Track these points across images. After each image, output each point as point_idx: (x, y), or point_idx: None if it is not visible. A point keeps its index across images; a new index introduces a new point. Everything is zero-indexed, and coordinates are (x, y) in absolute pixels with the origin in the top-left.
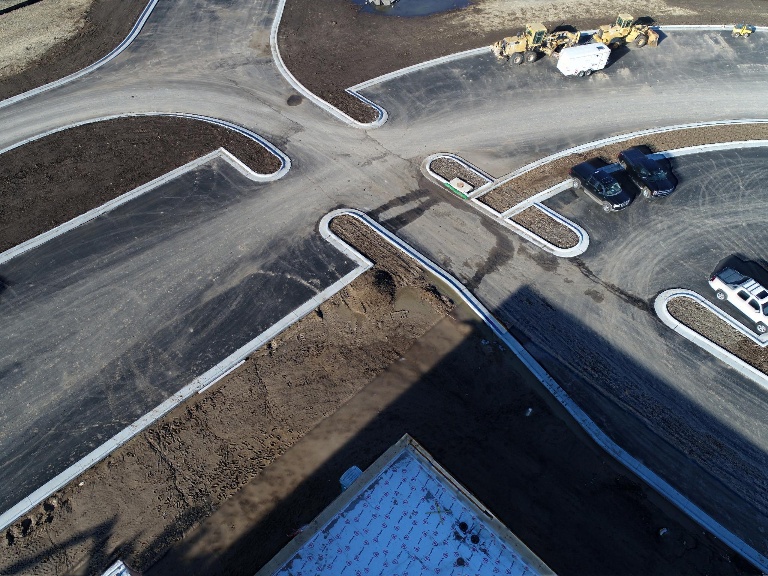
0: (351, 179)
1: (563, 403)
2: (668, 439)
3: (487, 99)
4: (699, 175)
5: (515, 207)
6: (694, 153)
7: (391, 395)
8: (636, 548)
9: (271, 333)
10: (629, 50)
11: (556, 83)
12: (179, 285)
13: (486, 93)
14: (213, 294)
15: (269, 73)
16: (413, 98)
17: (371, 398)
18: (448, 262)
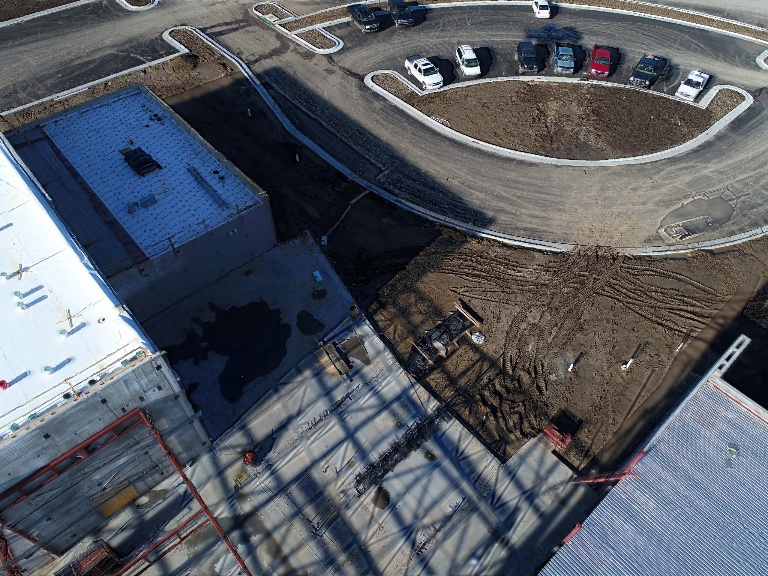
0: (197, 12)
1: (275, 113)
2: (332, 130)
3: None
4: (443, 18)
5: (302, 29)
6: (449, 7)
7: (170, 105)
8: (280, 165)
9: None
10: None
11: None
12: (60, 56)
13: None
14: (80, 61)
15: None
16: None
17: None
18: (241, 53)
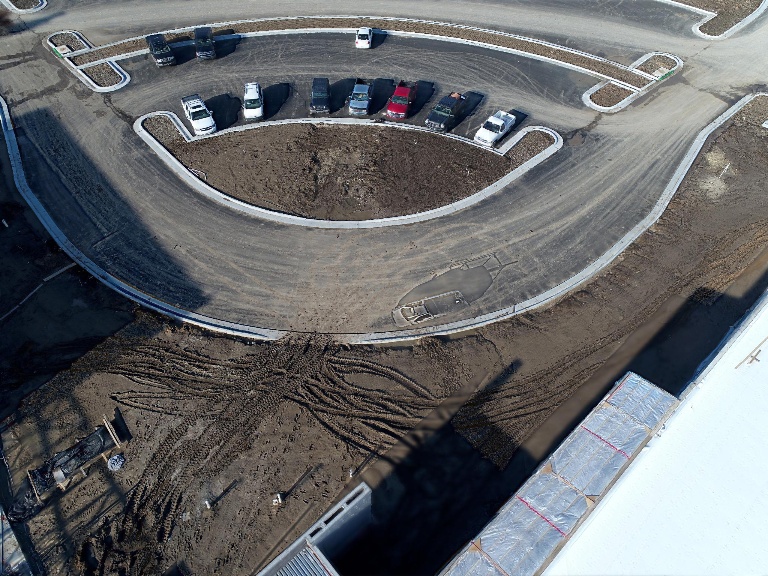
0: None
1: (12, 165)
2: (68, 186)
3: None
4: (254, 48)
5: (91, 63)
6: (266, 35)
7: None
8: None
9: None
10: None
11: None
12: None
13: None
14: None
15: None
16: None
17: None
18: (9, 92)
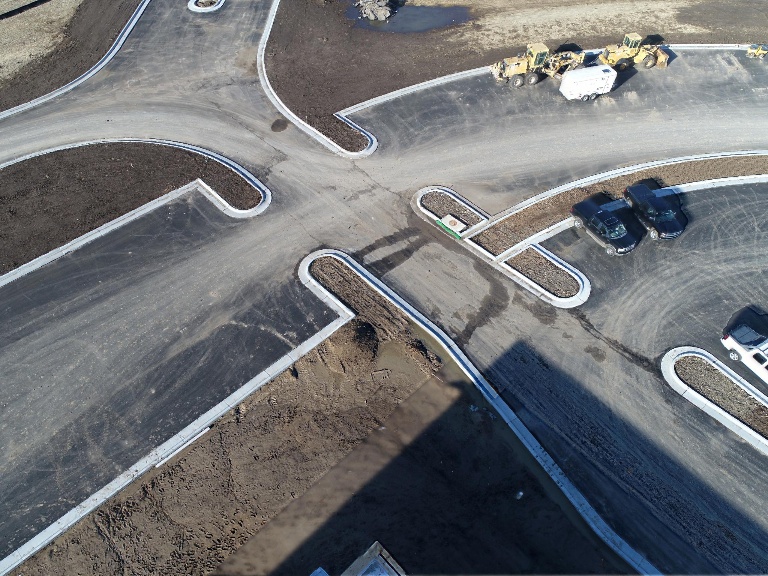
0: (335, 215)
1: (558, 484)
2: (675, 529)
3: (484, 125)
4: (711, 214)
5: (511, 249)
6: (705, 188)
7: (368, 472)
8: None
9: (240, 396)
10: (637, 71)
11: (558, 108)
12: (143, 337)
13: (483, 118)
14: (179, 348)
15: (254, 95)
16: (405, 124)
17: (345, 476)
18: (436, 313)
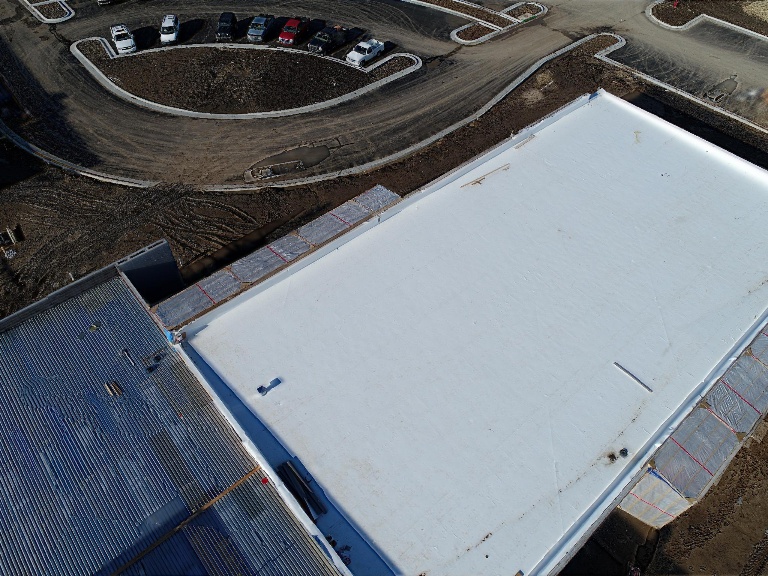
0: None
1: None
2: (9, 87)
3: None
4: None
5: (44, 2)
6: None
7: None
8: None
9: None
10: None
11: None
12: None
13: None
14: None
15: None
16: None
17: None
18: None
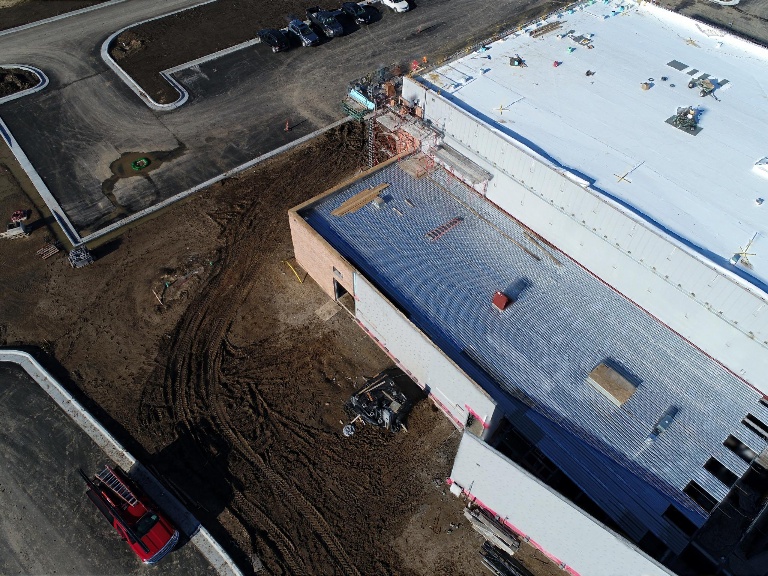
0: None
1: None
2: None
3: None
4: None
5: None
6: None
7: None
8: None
9: None
10: None
11: None
12: (511, 3)
13: None
14: (531, 7)
15: None
16: None
17: None
18: (658, 3)
